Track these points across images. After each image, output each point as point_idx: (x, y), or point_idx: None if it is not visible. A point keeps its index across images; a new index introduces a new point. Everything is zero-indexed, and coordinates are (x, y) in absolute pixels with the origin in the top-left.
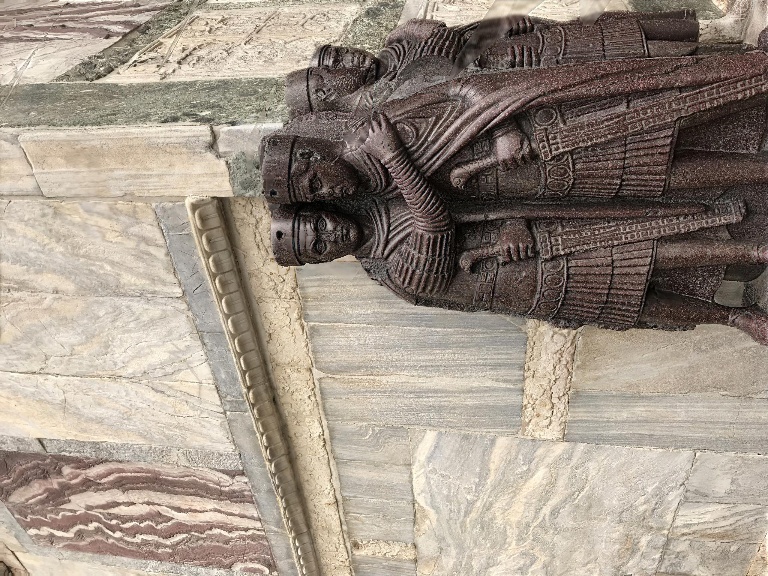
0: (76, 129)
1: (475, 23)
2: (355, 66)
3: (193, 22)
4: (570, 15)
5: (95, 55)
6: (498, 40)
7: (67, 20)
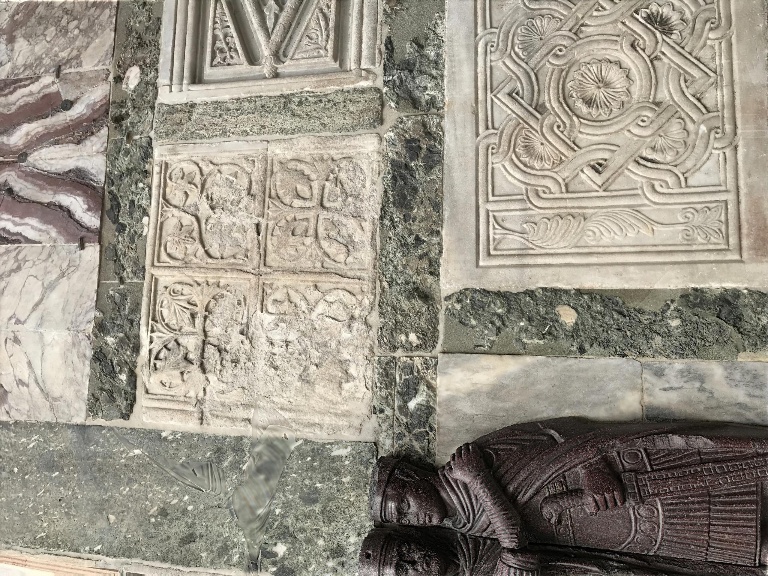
0: (170, 569)
1: (554, 473)
2: (421, 525)
3: (168, 191)
4: (687, 233)
5: (97, 323)
6: (582, 513)
7: (3, 162)
